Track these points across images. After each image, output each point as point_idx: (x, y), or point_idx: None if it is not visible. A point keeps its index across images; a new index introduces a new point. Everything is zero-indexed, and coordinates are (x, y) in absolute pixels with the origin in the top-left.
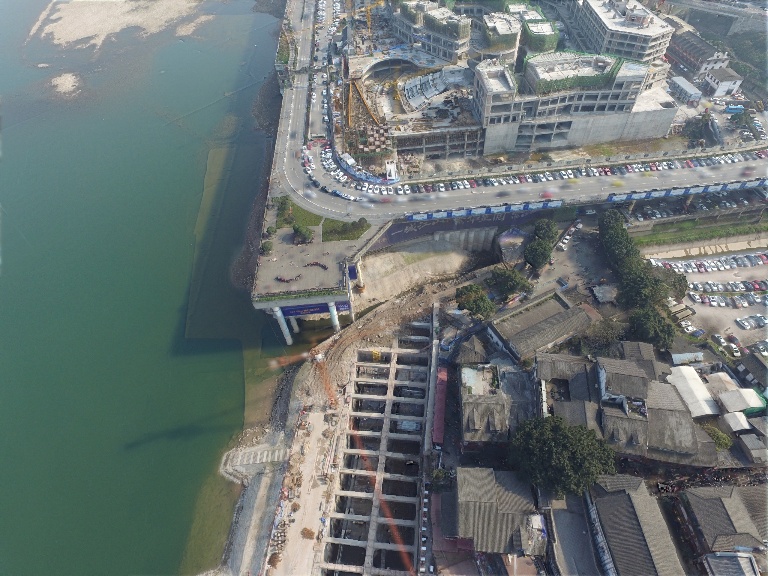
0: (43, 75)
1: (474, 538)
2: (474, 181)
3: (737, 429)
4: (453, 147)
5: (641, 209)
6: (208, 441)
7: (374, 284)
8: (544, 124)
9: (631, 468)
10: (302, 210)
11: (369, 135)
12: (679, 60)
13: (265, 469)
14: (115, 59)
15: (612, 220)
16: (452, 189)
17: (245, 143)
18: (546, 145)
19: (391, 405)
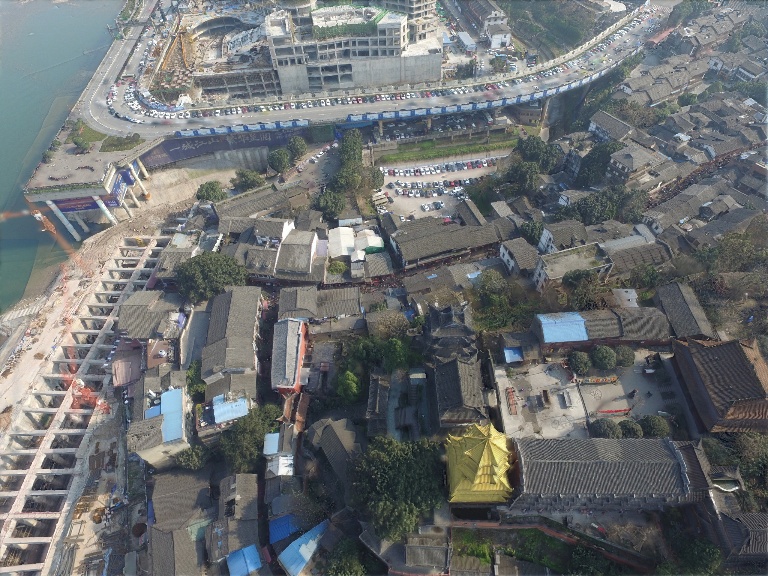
0: None
1: (128, 329)
2: (247, 108)
3: (354, 260)
4: (254, 88)
5: (391, 132)
6: None
7: (159, 194)
8: (327, 66)
9: (272, 290)
10: (91, 130)
11: (175, 76)
12: (472, 19)
13: (23, 321)
14: None
15: (350, 136)
16: (226, 114)
17: None
18: (336, 86)
19: (137, 274)
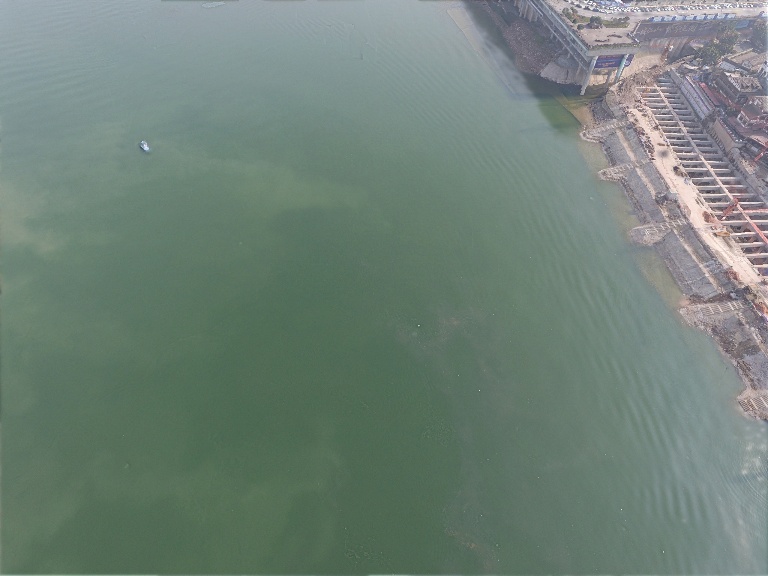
0: None
1: None
2: None
3: None
4: (637, 1)
5: None
6: (566, 129)
7: None
8: None
9: None
10: None
11: None
12: None
13: (616, 131)
14: None
15: (762, 27)
16: (664, 10)
17: (469, 7)
18: None
19: (671, 106)
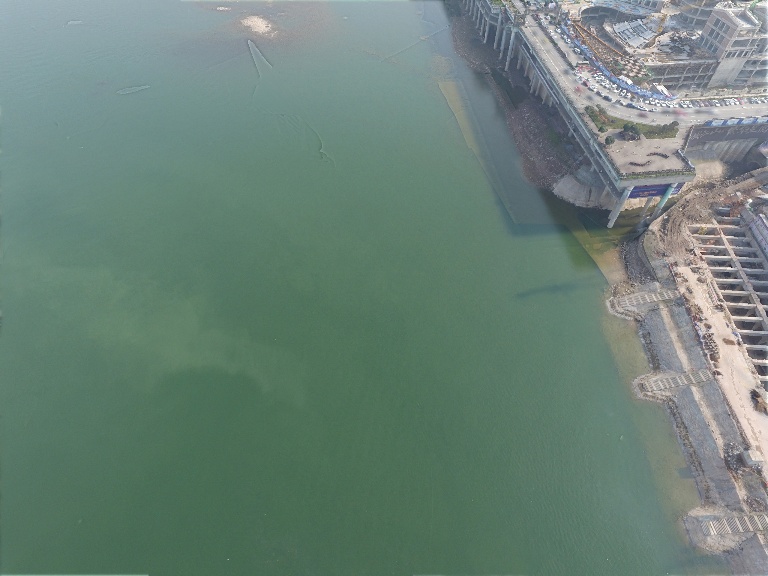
0: (228, 17)
1: None
2: None
3: None
4: (685, 79)
5: None
6: (586, 293)
7: None
8: (767, 60)
9: None
10: (612, 117)
11: (622, 64)
12: None
13: (659, 306)
14: (291, 5)
15: None
16: (725, 105)
17: (467, 78)
18: (760, 80)
19: (738, 262)
